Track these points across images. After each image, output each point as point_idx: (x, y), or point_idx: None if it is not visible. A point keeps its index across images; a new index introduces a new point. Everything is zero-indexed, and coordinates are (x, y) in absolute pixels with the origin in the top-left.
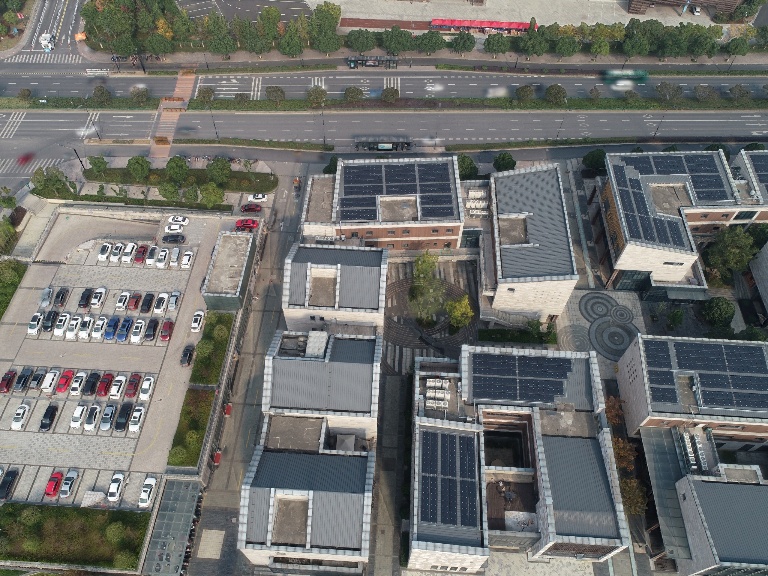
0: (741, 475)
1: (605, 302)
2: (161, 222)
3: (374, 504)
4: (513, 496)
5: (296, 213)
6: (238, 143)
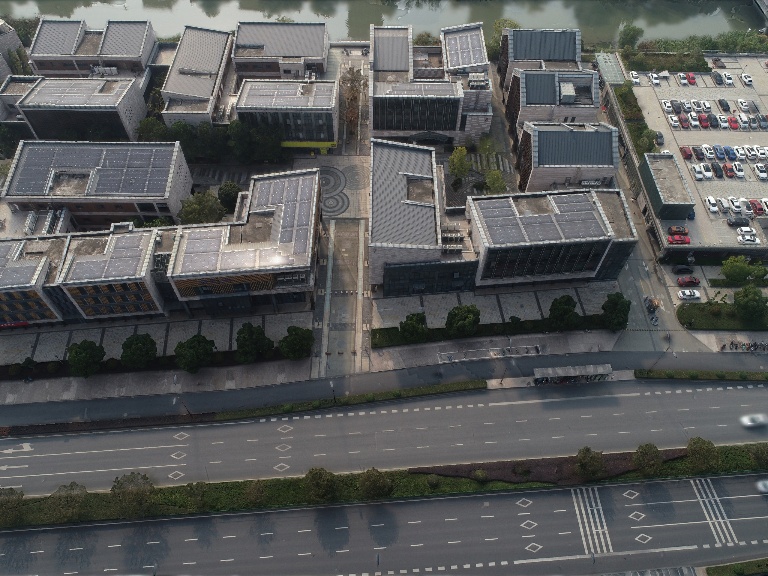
0: (292, 60)
1: (325, 208)
2: (764, 236)
3: (499, 93)
4: (424, 62)
5: (638, 281)
6: (763, 372)
